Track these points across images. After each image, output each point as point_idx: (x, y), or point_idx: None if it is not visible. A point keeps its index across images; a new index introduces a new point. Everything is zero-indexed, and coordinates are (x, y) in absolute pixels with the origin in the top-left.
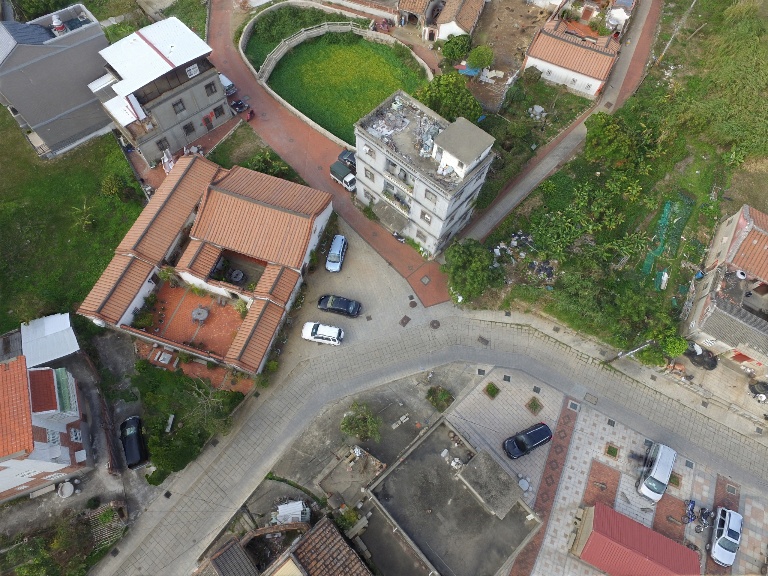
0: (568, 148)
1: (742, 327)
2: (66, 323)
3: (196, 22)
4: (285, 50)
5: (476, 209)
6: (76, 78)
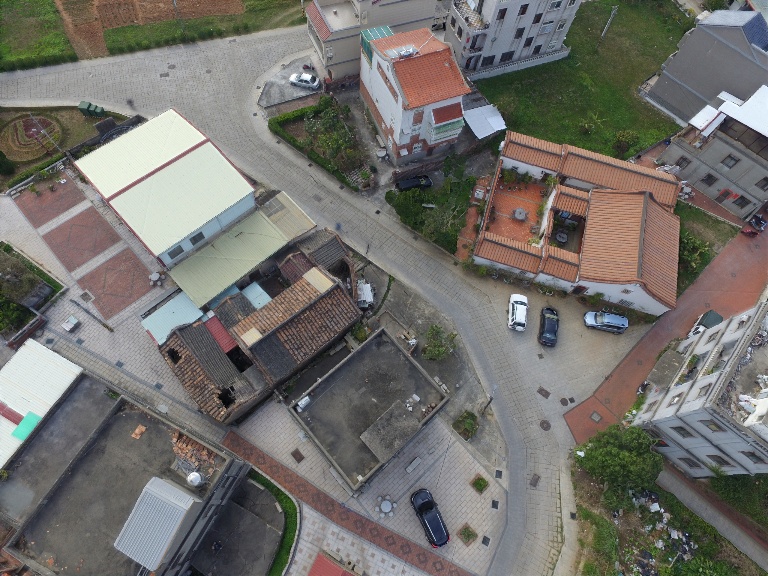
0: None
1: None
2: (498, 128)
3: None
4: None
5: (711, 486)
6: (727, 81)
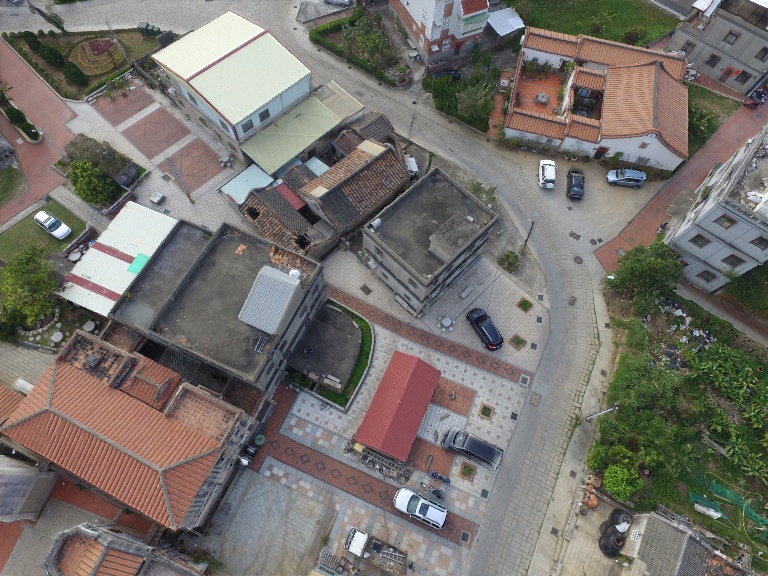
0: None
1: (670, 569)
2: (518, 27)
3: None
4: None
5: (726, 297)
6: None
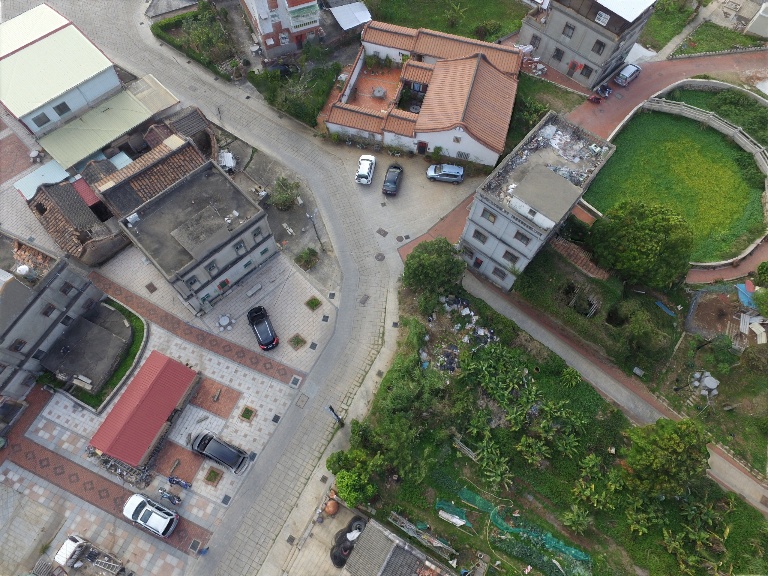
0: (654, 423)
1: None
2: (364, 20)
3: (705, 45)
4: (701, 118)
5: None
6: None
